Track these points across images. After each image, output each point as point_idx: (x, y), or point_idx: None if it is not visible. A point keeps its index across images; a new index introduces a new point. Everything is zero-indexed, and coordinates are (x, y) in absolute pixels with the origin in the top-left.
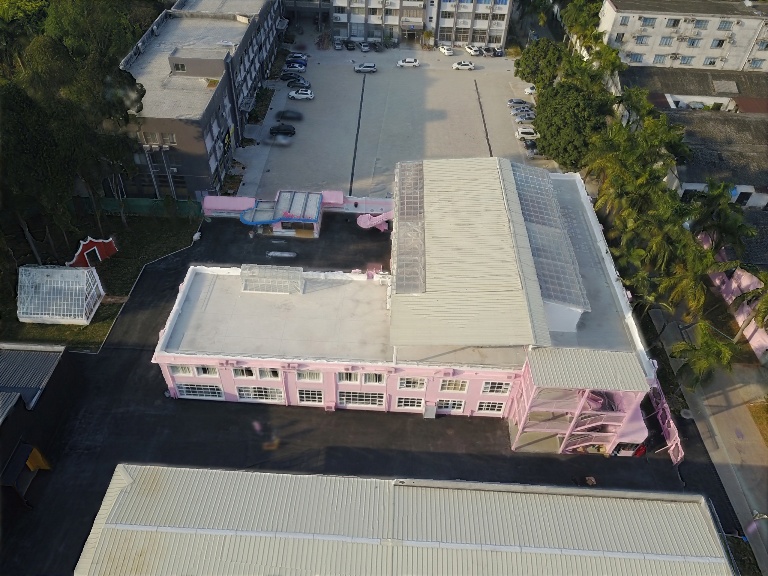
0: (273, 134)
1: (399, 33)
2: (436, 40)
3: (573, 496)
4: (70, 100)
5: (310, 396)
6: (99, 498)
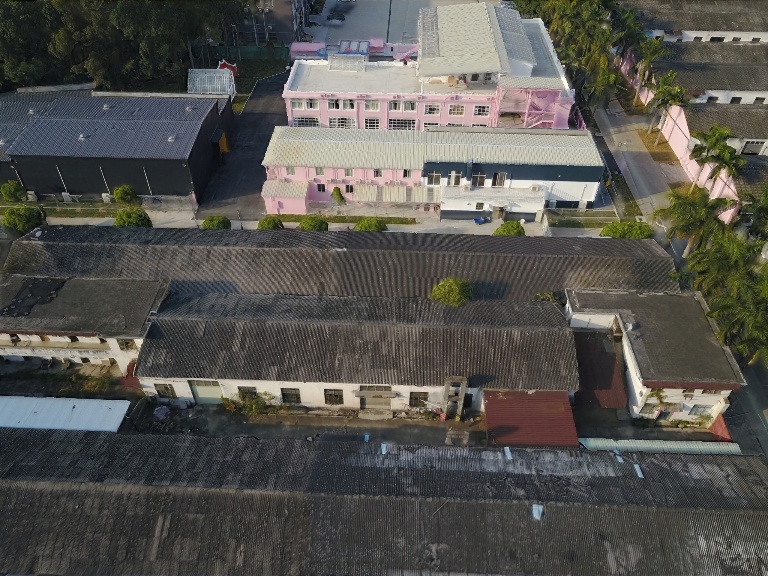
0: (329, 20)
1: None
2: None
3: (520, 134)
4: None
5: (372, 125)
6: (259, 162)
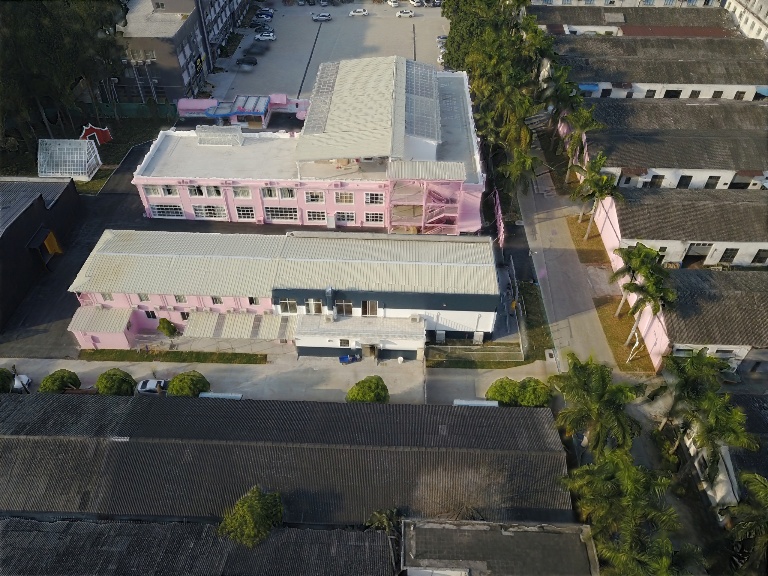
0: (239, 64)
1: None
2: None
3: (406, 241)
4: (72, 8)
5: (245, 213)
6: None
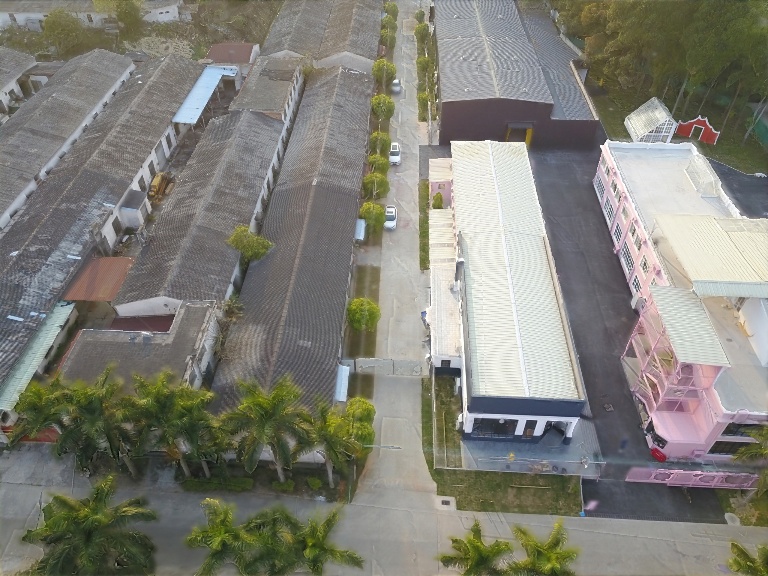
0: None
1: None
2: None
3: (562, 324)
4: (765, 10)
5: None
6: None
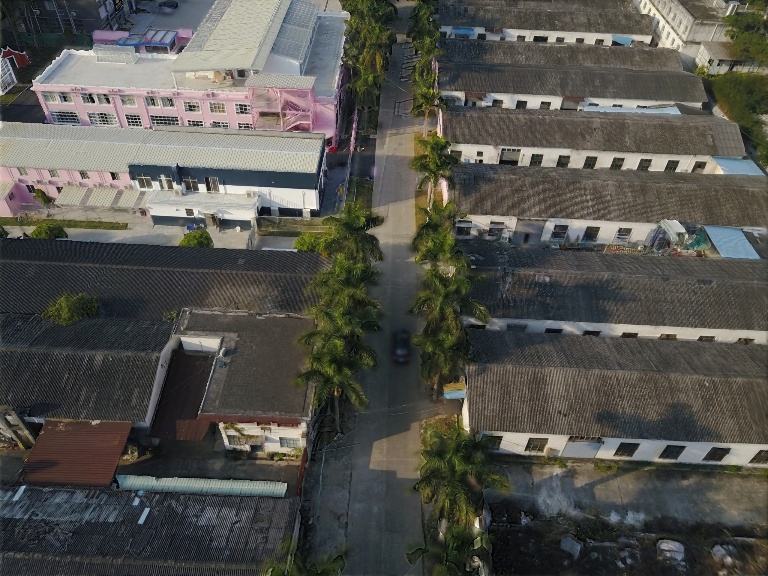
0: None
1: None
2: None
3: (254, 136)
4: None
5: (134, 121)
6: None
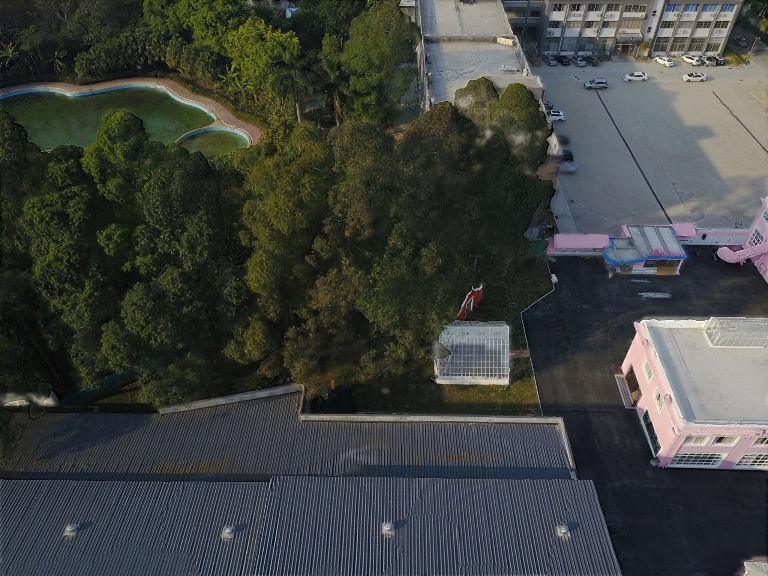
0: None
1: (612, 45)
2: (650, 51)
3: None
4: None
5: None
6: None
